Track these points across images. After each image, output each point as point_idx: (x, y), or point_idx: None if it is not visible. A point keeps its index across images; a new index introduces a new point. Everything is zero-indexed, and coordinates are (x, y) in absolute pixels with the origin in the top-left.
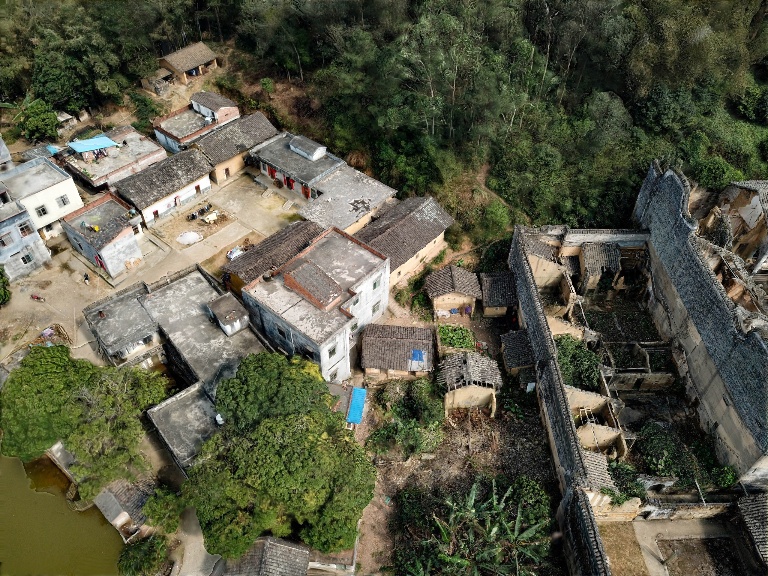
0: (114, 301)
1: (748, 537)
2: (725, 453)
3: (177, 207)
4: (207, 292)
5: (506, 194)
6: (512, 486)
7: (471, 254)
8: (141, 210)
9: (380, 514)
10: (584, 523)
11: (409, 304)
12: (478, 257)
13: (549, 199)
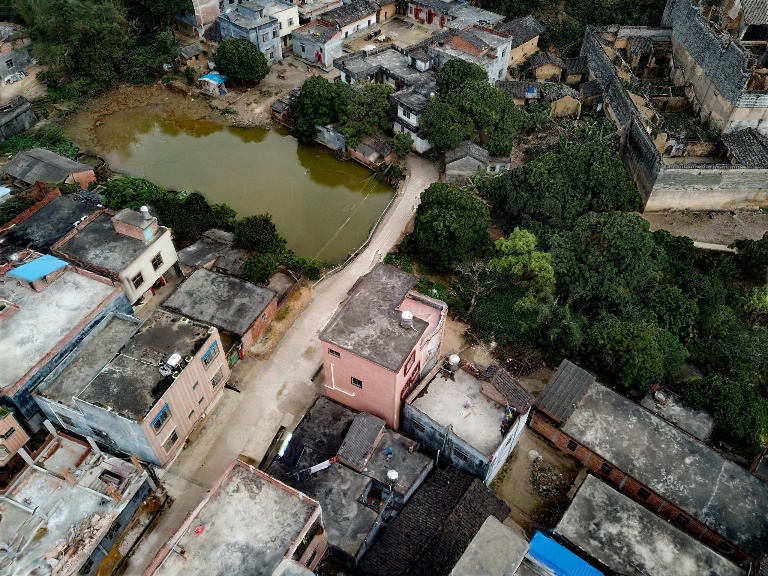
0: (347, 60)
1: (727, 161)
2: (715, 125)
3: (357, 33)
4: (401, 57)
5: (578, 16)
6: (597, 121)
7: (555, 53)
8: (340, 28)
9: (518, 158)
10: (637, 129)
11: (518, 78)
12: (560, 54)
13: (607, 14)
